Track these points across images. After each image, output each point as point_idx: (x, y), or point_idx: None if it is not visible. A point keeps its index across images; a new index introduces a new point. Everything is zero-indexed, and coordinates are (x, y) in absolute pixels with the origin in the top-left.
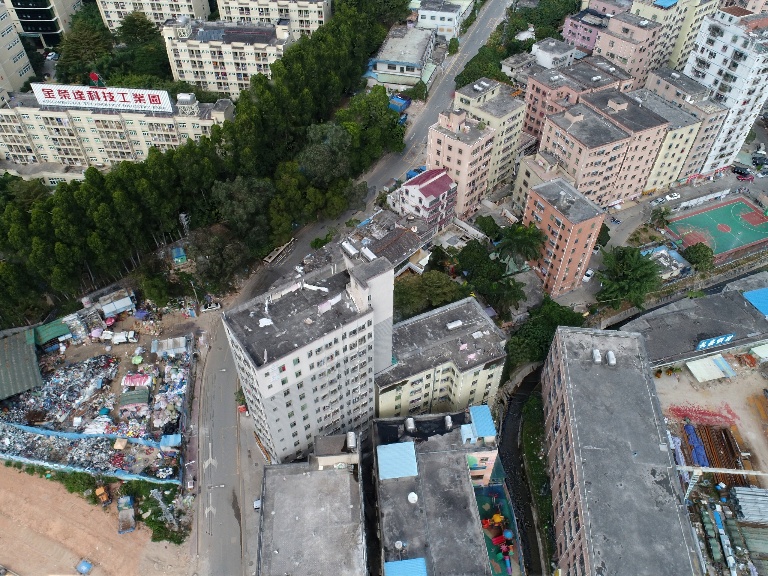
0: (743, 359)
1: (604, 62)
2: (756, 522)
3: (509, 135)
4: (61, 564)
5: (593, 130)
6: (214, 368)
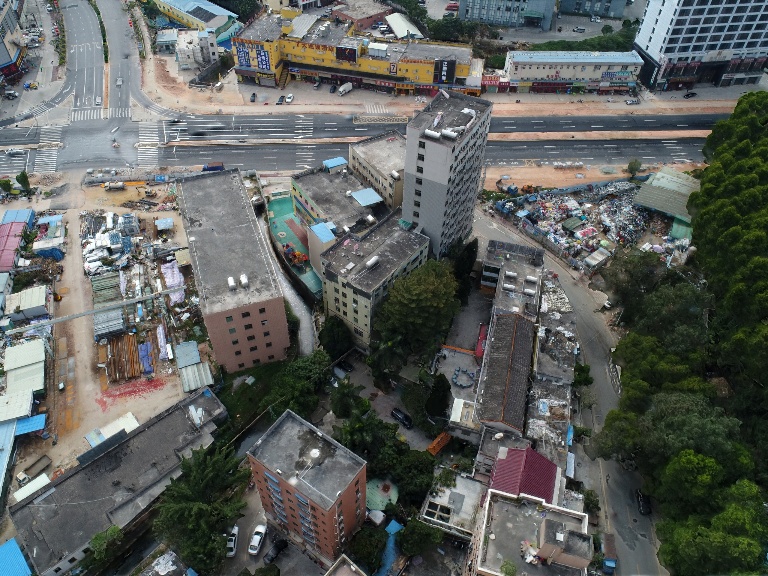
0: None
1: None
2: None
3: None
4: (518, 175)
5: None
6: (554, 268)
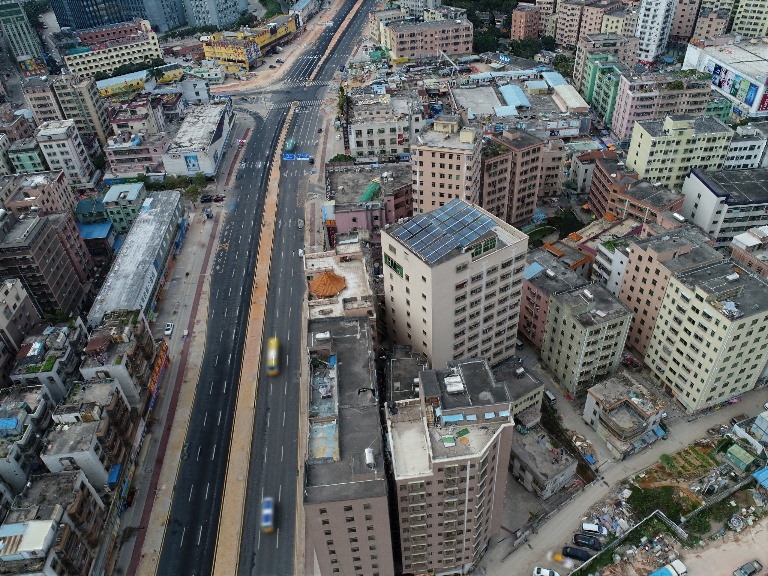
0: None
1: None
2: None
3: None
4: None
5: None
6: None
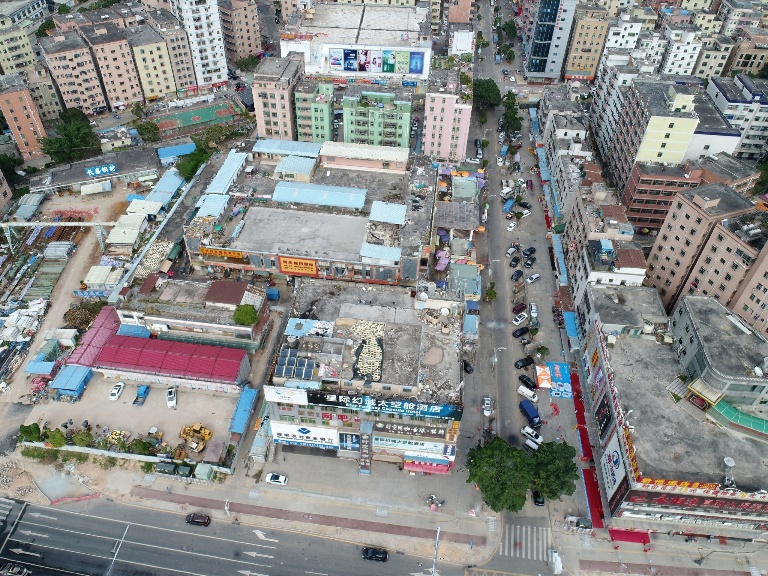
0: (131, 184)
1: (127, 8)
2: (55, 259)
3: (16, 54)
4: None
5: (66, 45)
6: None
